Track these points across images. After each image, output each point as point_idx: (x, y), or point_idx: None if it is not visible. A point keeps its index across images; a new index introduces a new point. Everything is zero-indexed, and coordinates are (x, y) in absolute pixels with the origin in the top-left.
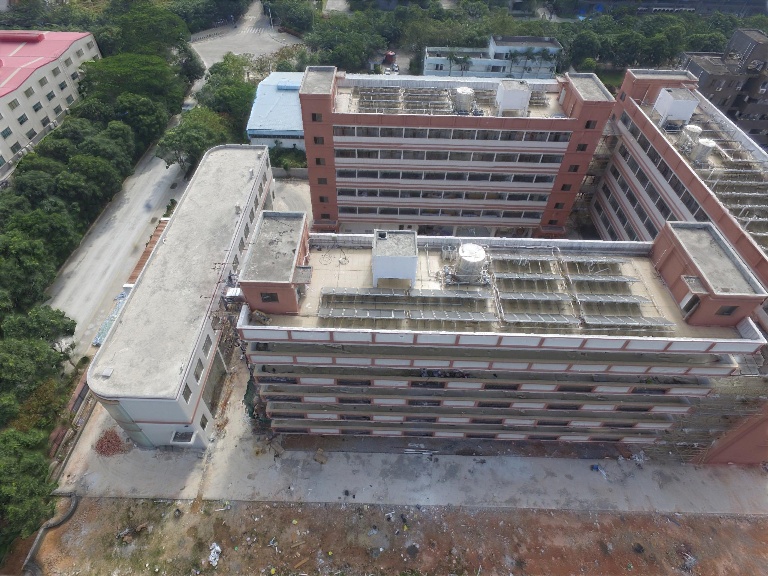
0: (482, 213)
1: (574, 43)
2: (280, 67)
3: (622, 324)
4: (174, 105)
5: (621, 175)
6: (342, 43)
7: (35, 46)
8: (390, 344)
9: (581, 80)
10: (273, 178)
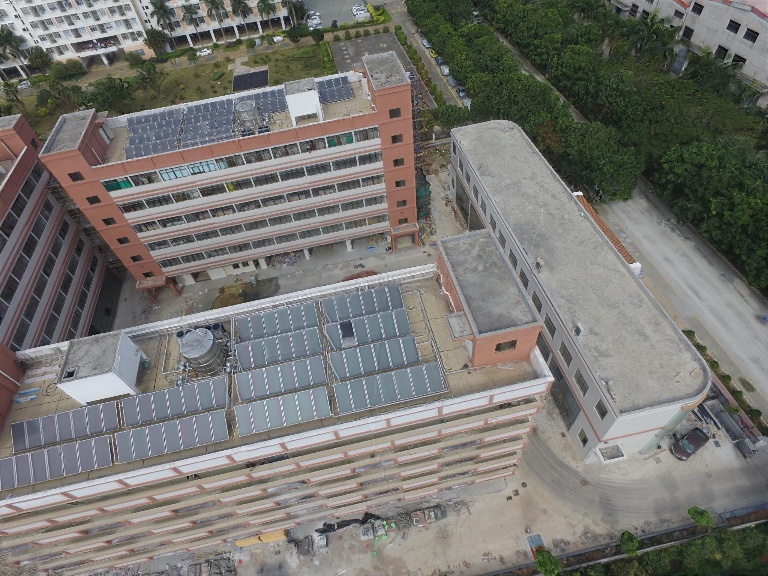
0: None
1: None
2: None
3: (161, 112)
4: None
5: None
6: None
7: None
8: None
9: None
10: (648, 540)
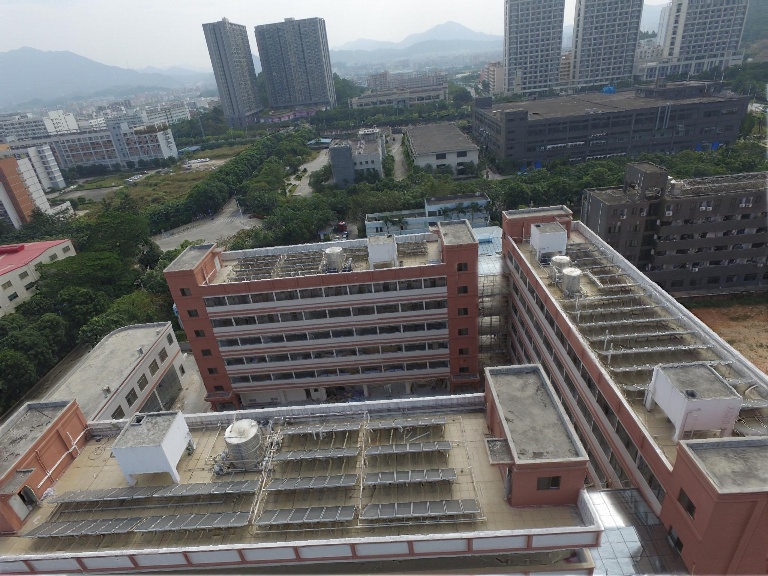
0: (384, 368)
1: (505, 194)
2: (233, 247)
3: (406, 516)
4: (120, 292)
5: (518, 313)
6: (296, 220)
7: (13, 256)
8: (107, 571)
9: (453, 227)
10: None
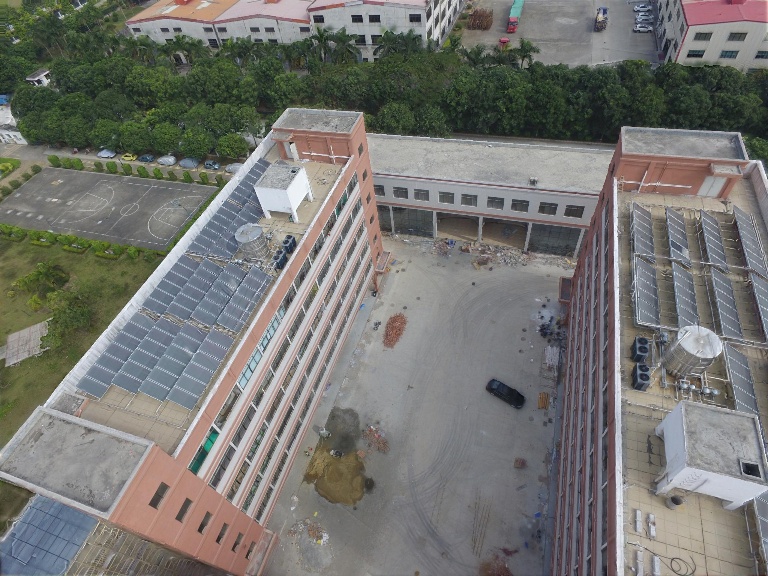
0: None
1: None
2: None
3: (115, 338)
4: None
5: None
6: None
7: None
8: None
9: None
10: None
